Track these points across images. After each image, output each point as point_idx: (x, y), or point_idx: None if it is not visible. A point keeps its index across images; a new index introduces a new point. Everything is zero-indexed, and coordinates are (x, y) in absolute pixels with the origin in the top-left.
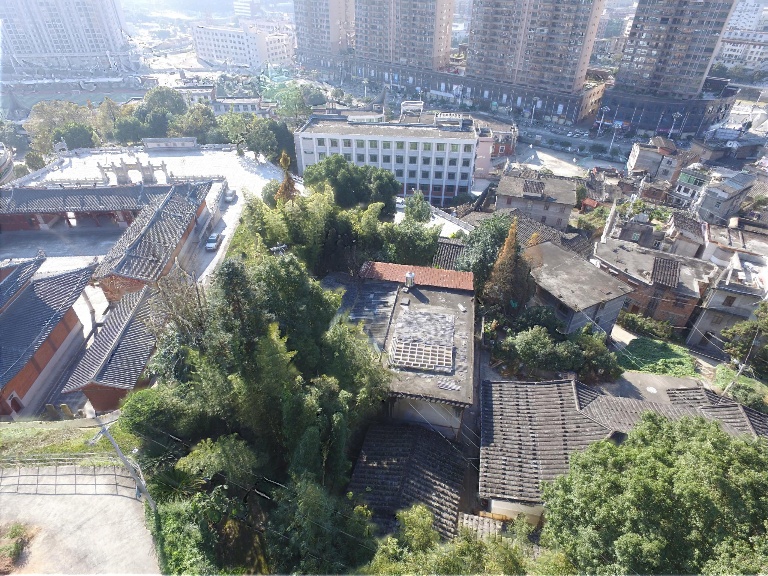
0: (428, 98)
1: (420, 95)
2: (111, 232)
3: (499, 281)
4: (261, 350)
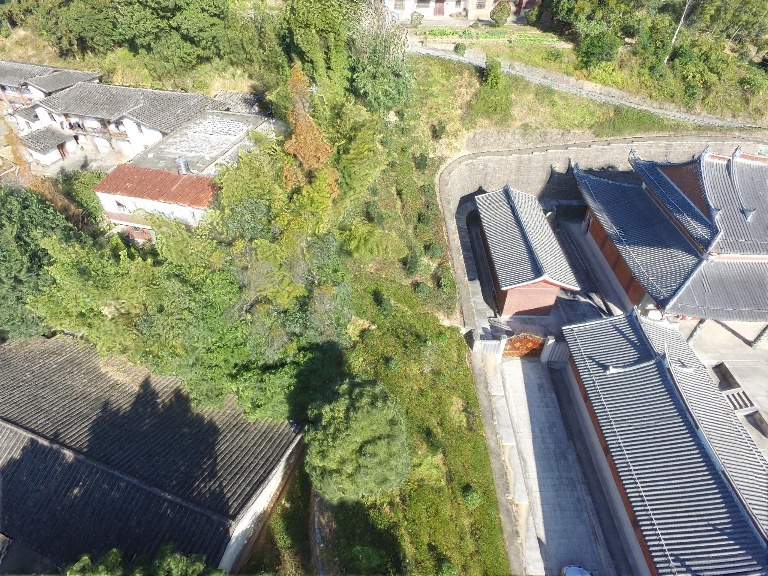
0: None
1: None
2: None
3: None
4: None
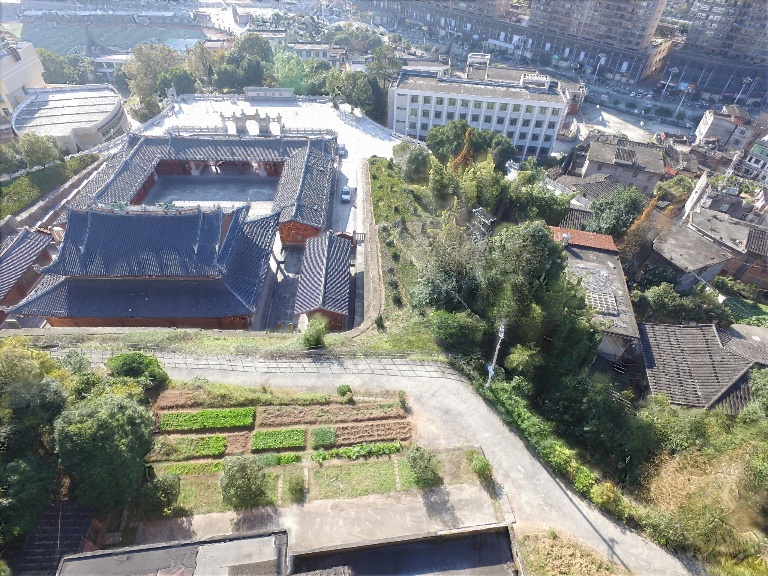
0: None
1: (483, 46)
2: (253, 180)
3: (631, 244)
4: (538, 289)
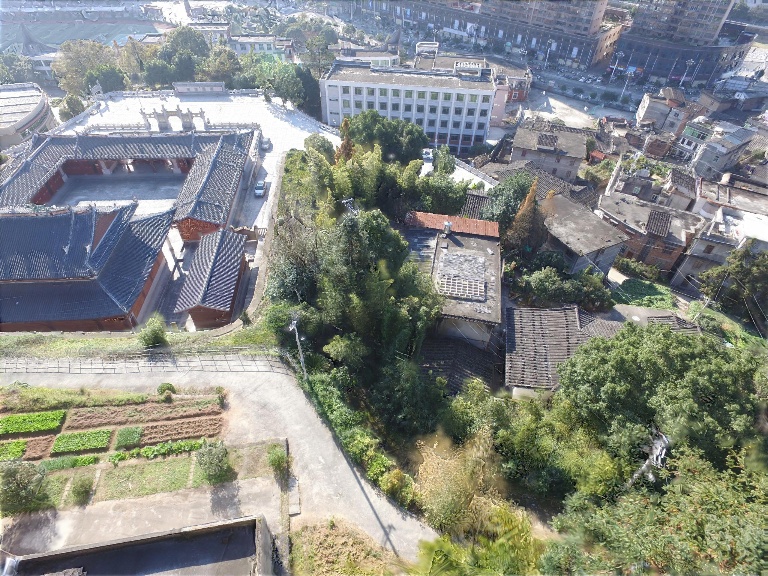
0: (441, 36)
1: (434, 34)
2: (167, 178)
3: (519, 230)
4: (365, 279)
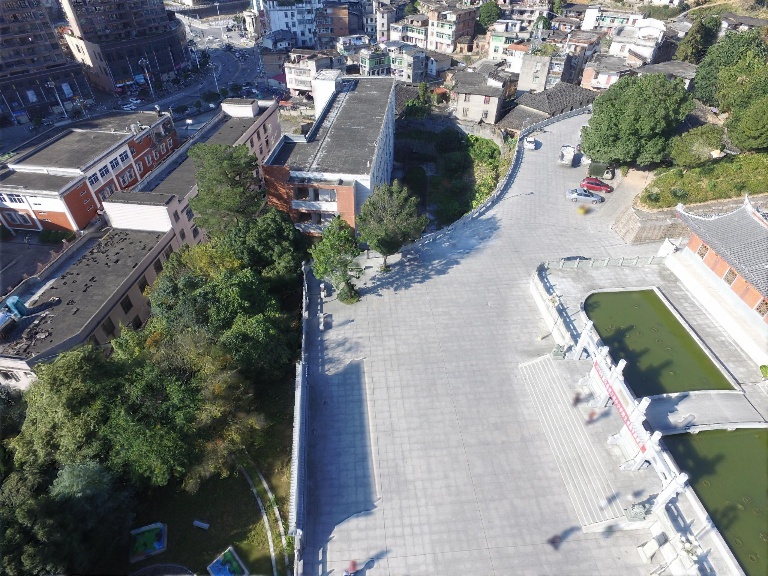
0: None
1: None
2: None
3: None
4: None
